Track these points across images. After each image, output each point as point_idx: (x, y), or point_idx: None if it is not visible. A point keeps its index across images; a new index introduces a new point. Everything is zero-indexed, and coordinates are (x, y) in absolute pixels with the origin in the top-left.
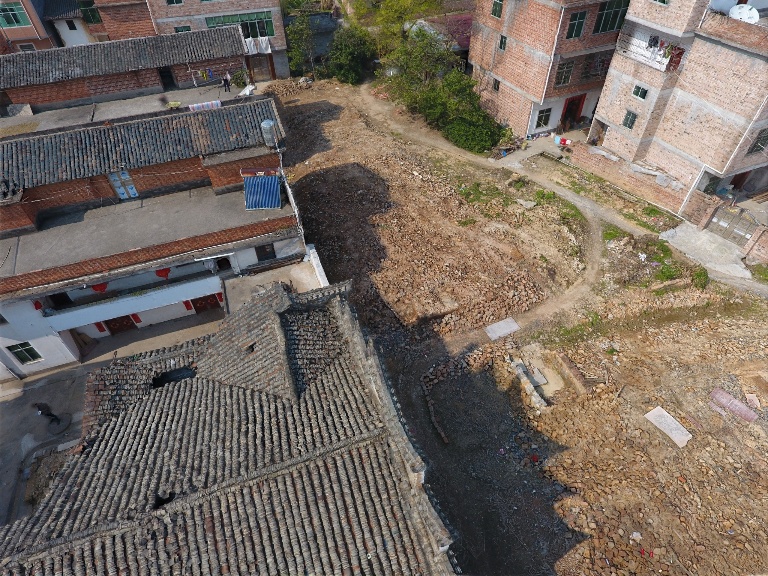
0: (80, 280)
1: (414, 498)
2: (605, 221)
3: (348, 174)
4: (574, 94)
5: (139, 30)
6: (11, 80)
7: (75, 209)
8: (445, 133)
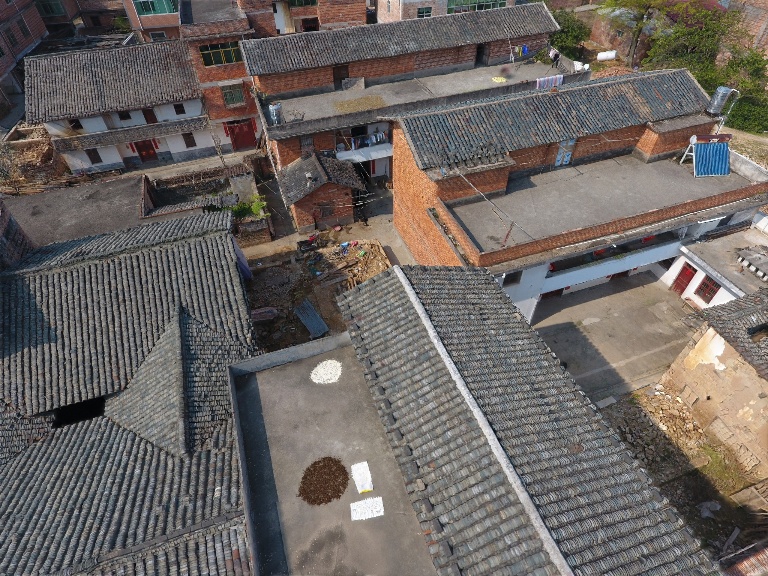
0: (602, 240)
1: None
2: None
3: None
4: None
5: (349, 13)
6: (356, 53)
7: (520, 175)
8: None
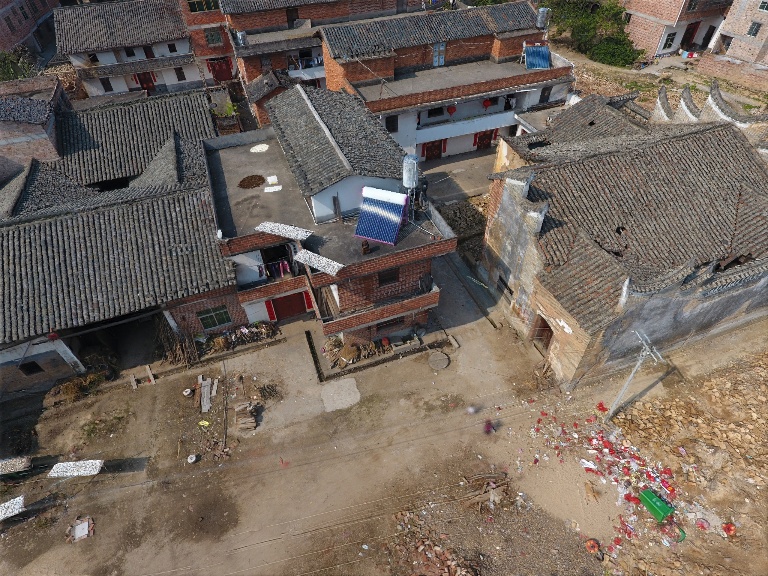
0: None
1: (760, 145)
2: (740, 102)
3: None
4: (697, 20)
5: None
6: None
7: (407, 71)
8: (589, 55)
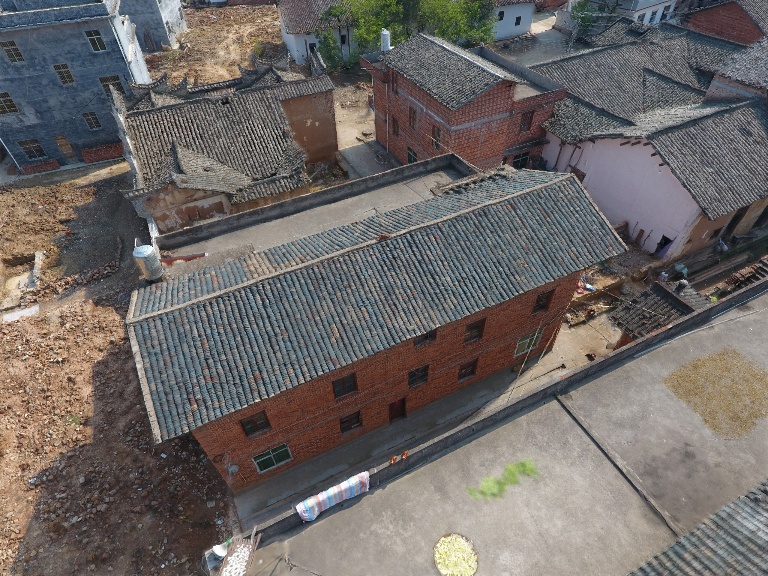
0: None
1: None
2: None
3: None
4: None
5: None
6: None
7: None
8: None
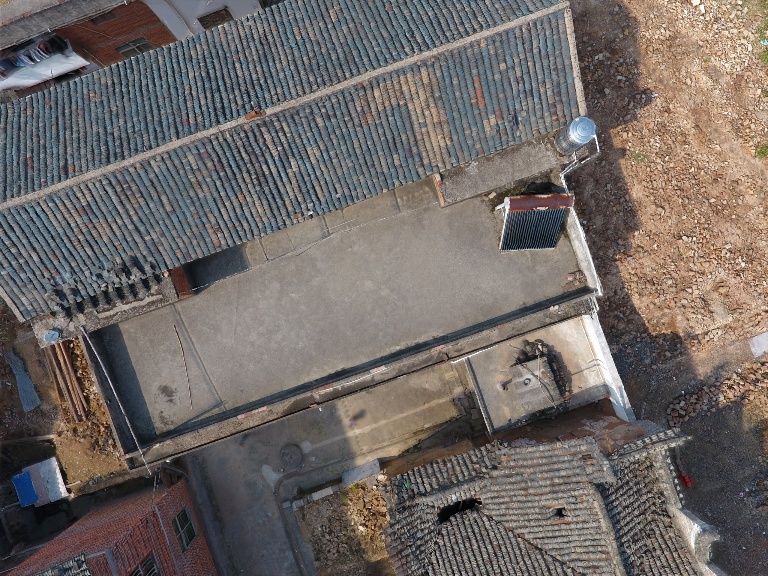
0: (308, 397)
1: None
2: None
3: (576, 2)
4: None
5: None
6: None
7: None
8: None
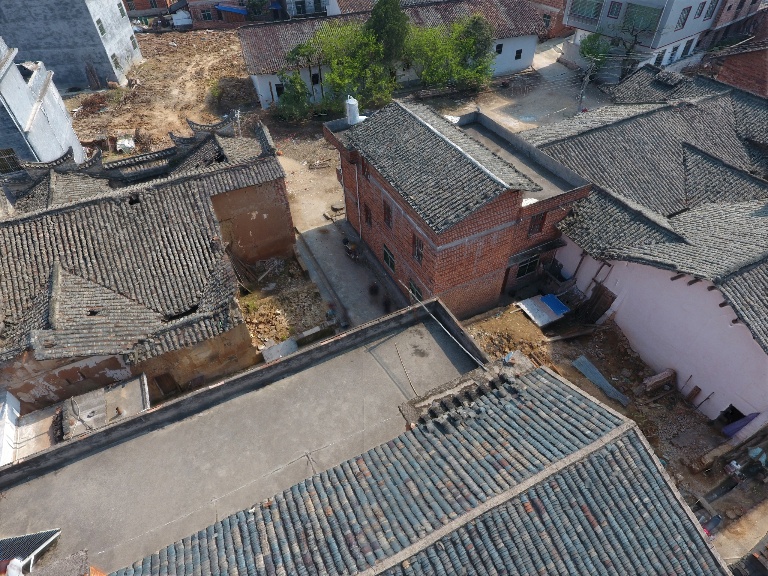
0: None
1: None
2: None
3: None
4: None
5: None
6: None
7: None
8: None
